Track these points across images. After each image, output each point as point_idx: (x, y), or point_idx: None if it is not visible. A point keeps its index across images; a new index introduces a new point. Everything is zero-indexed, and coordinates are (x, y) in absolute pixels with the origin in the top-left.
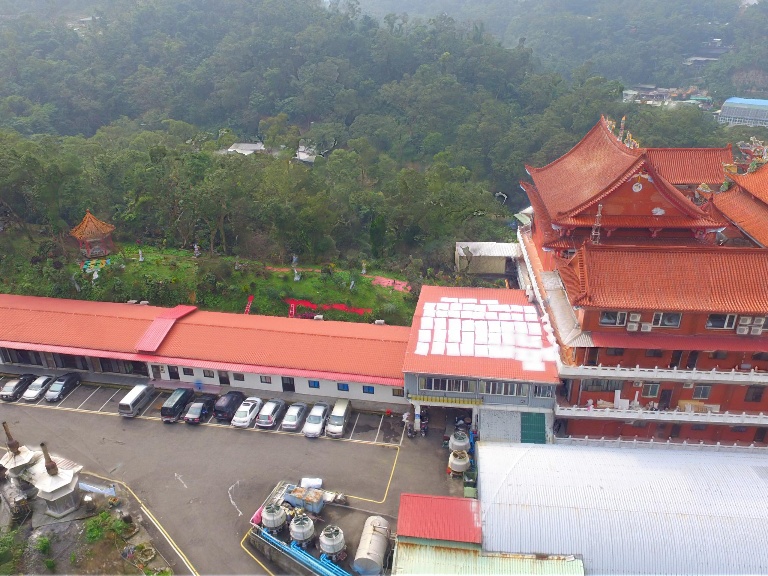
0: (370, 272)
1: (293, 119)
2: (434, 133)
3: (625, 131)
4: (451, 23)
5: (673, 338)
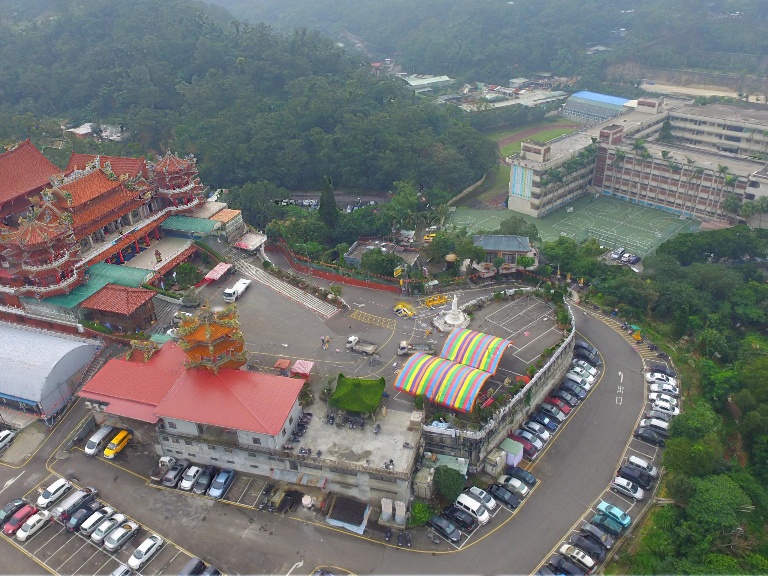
0: None
1: (126, 107)
2: (179, 125)
3: (320, 130)
4: (268, 30)
5: None
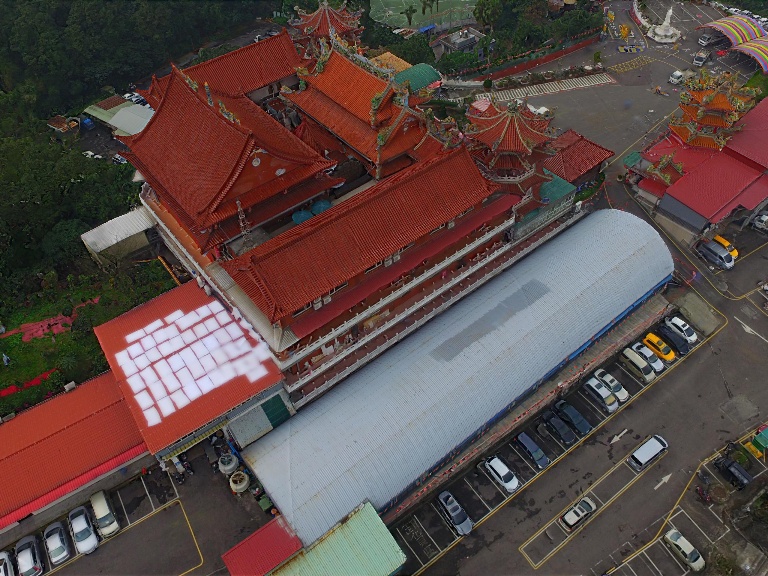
0: (9, 325)
1: None
2: None
3: None
4: None
5: (347, 295)
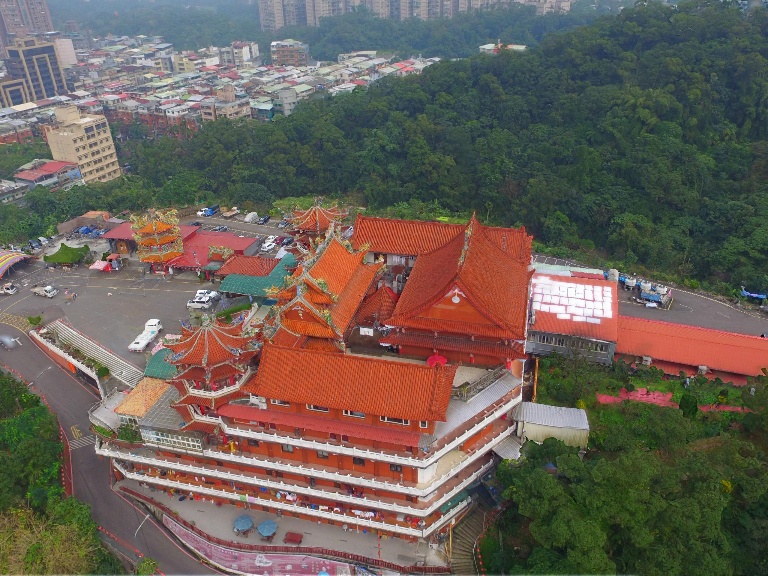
0: None
1: None
2: None
3: None
4: None
5: None
